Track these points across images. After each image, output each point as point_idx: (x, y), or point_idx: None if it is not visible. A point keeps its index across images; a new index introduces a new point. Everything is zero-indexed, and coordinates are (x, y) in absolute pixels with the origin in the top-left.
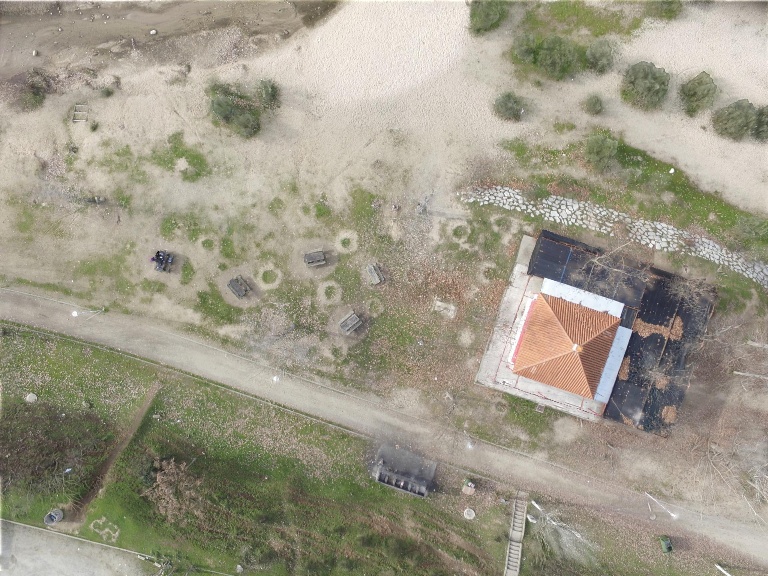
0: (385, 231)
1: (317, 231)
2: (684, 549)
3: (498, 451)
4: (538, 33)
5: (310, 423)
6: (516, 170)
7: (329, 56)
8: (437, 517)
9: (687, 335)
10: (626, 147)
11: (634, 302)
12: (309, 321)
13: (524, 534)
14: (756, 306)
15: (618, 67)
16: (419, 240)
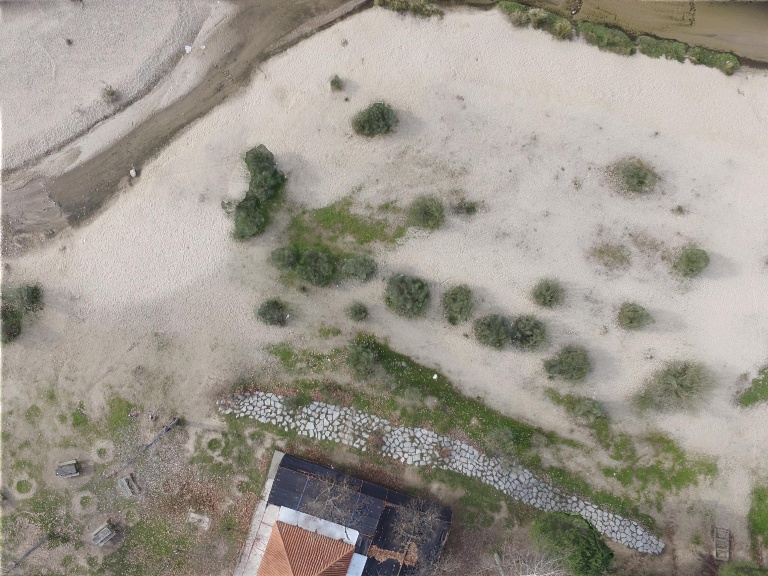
0: (141, 441)
1: (73, 440)
2: None
3: None
4: (304, 239)
5: None
6: (281, 375)
7: (93, 258)
8: None
9: None
10: (391, 353)
11: (369, 530)
12: (64, 530)
13: None
14: (505, 518)
15: (382, 275)
16: (175, 451)
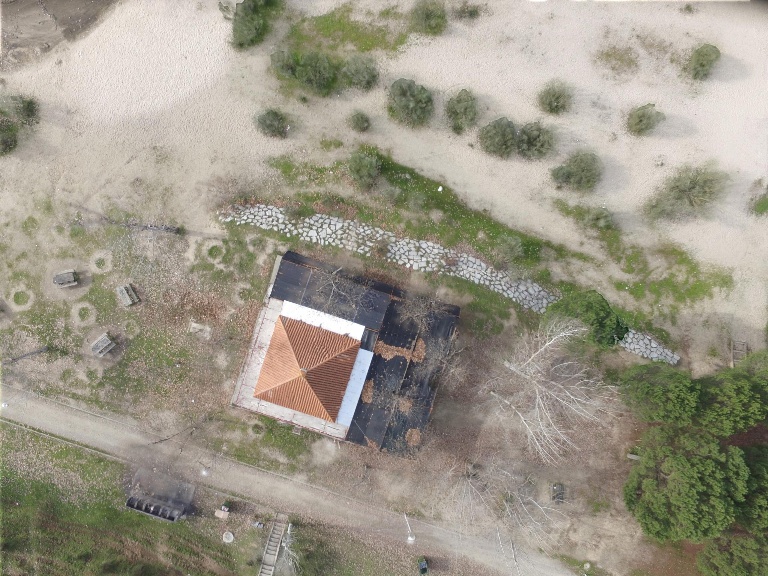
0: (140, 251)
1: (71, 251)
2: (443, 569)
3: (258, 473)
4: (303, 48)
5: (65, 447)
6: (282, 188)
7: (90, 70)
8: (194, 541)
9: (429, 357)
10: (394, 165)
11: (375, 324)
12: (63, 343)
13: (277, 557)
14: (514, 326)
15: (384, 83)
16: (175, 260)
